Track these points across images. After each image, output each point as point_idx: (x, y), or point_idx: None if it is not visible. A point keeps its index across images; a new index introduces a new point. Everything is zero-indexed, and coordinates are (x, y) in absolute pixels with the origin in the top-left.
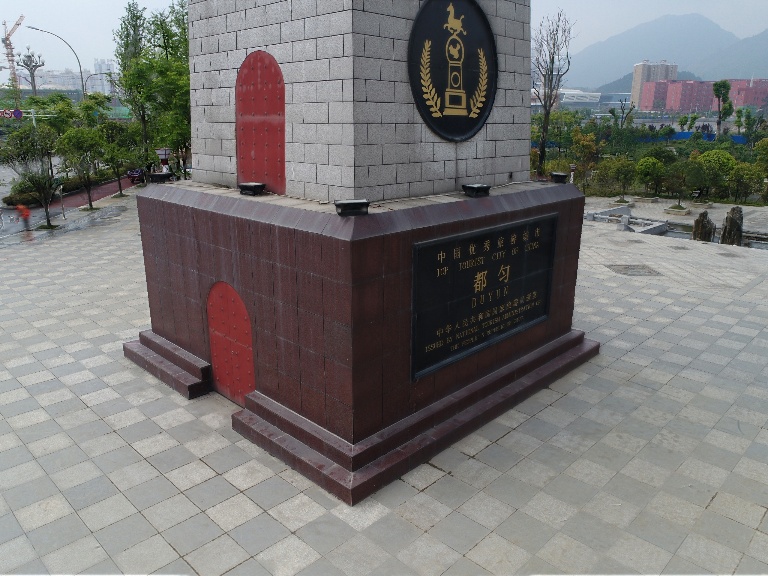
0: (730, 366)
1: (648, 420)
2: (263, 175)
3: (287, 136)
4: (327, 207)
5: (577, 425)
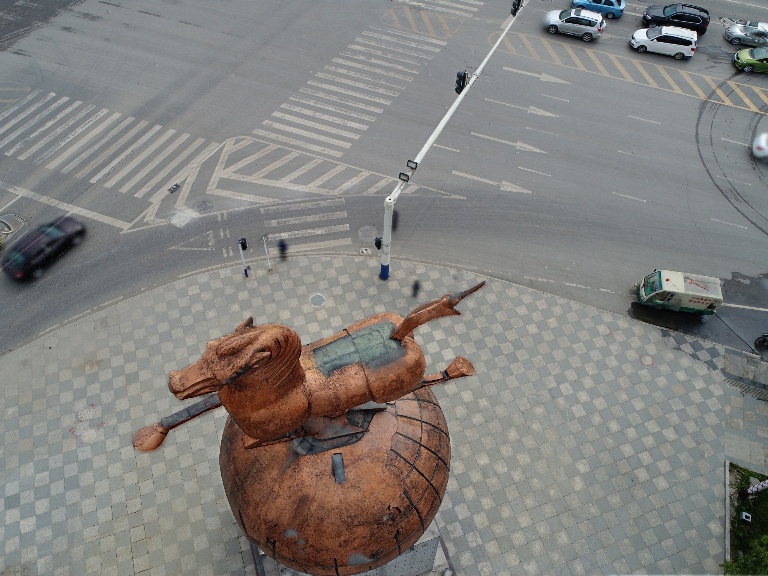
0: None
1: None
2: None
3: None
4: None
5: None
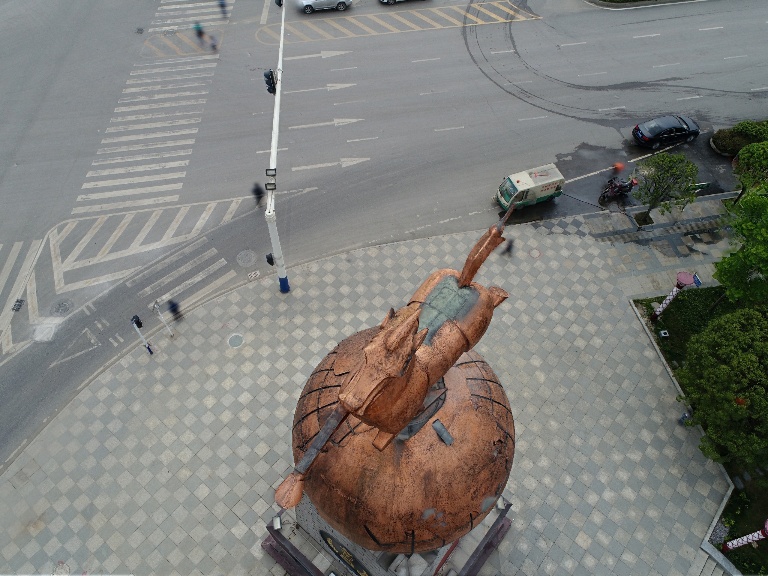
0: None
1: None
2: None
3: None
4: None
5: None
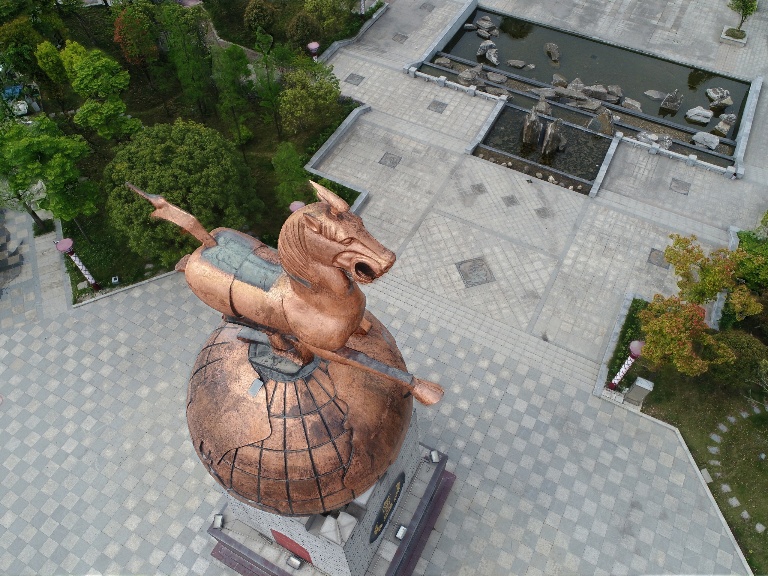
0: (516, 476)
1: (477, 550)
2: None
3: None
4: None
5: (448, 564)
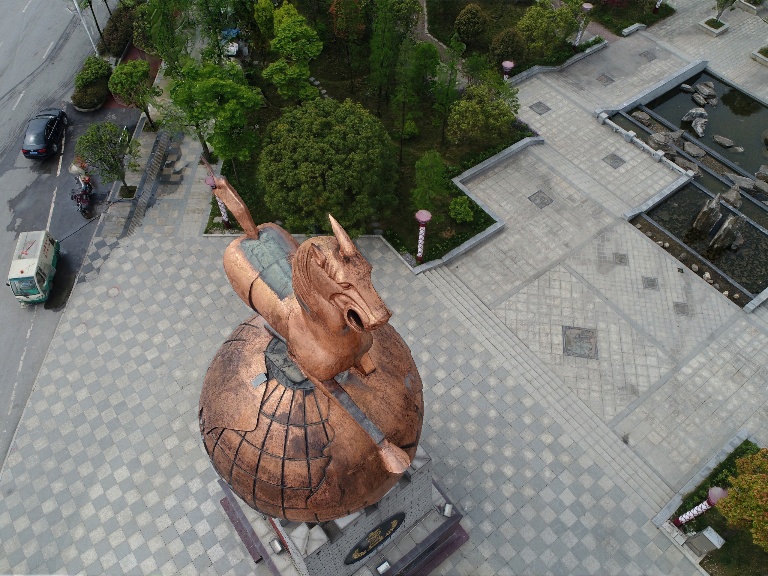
0: (530, 567)
1: None
2: (281, 539)
3: (290, 552)
4: None
5: None
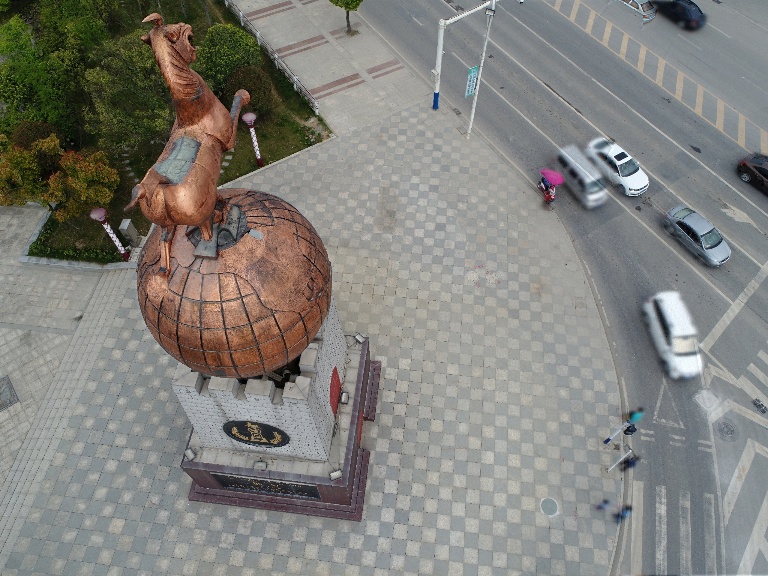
0: None
1: None
2: None
3: None
4: (354, 355)
5: None
